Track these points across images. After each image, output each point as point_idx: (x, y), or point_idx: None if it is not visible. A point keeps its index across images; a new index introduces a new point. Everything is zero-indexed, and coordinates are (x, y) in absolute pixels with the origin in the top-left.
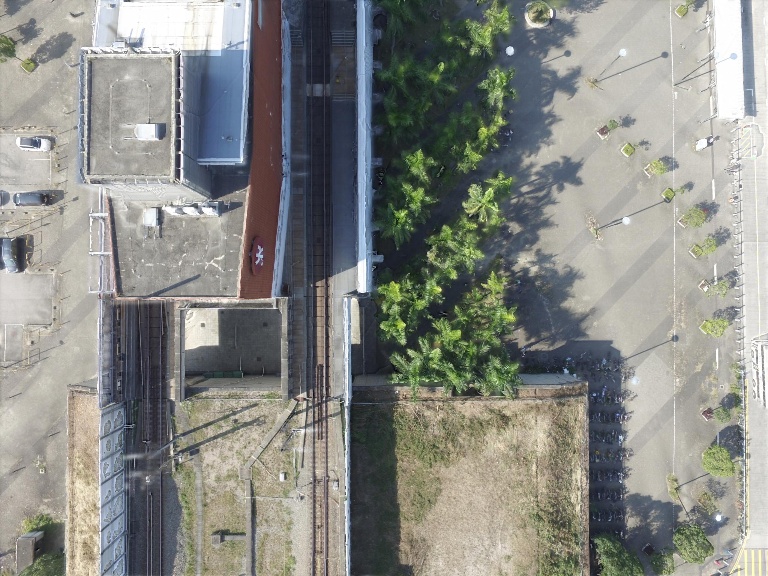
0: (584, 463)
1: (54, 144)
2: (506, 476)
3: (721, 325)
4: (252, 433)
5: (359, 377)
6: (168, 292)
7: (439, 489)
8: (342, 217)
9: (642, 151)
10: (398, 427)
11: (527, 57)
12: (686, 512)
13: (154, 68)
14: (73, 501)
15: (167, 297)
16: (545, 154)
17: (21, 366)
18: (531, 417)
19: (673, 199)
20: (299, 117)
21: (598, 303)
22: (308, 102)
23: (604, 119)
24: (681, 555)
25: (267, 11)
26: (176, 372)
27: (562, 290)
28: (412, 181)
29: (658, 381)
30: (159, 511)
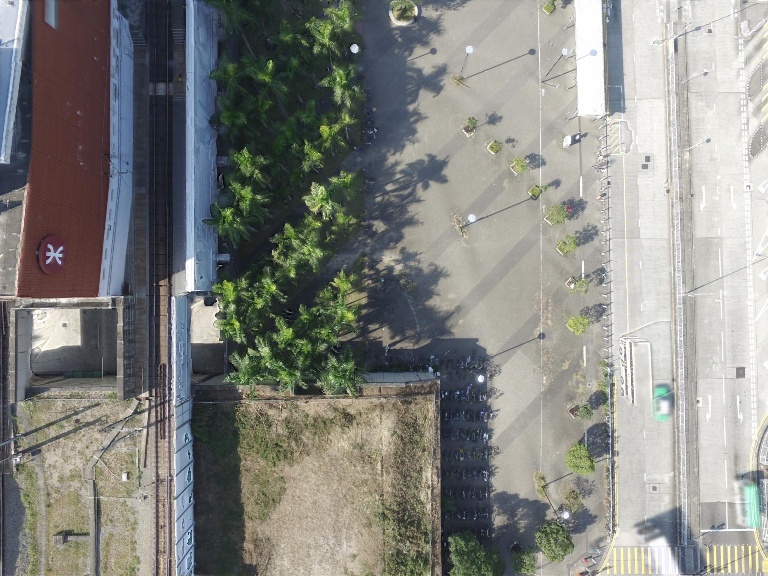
0: (435, 461)
1: None
2: (351, 475)
3: (582, 322)
4: (94, 433)
5: (219, 376)
6: None
7: (283, 488)
8: (182, 216)
9: (508, 148)
10: (241, 426)
11: (392, 55)
12: (554, 510)
13: None
14: None
15: None
16: (410, 152)
17: None
18: (376, 415)
19: (540, 196)
20: (141, 116)
21: (464, 301)
22: (151, 101)
23: (470, 116)
24: (543, 553)
25: (70, 9)
26: (11, 372)
27: (427, 288)
28: (243, 179)
29: (524, 379)
30: (0, 512)
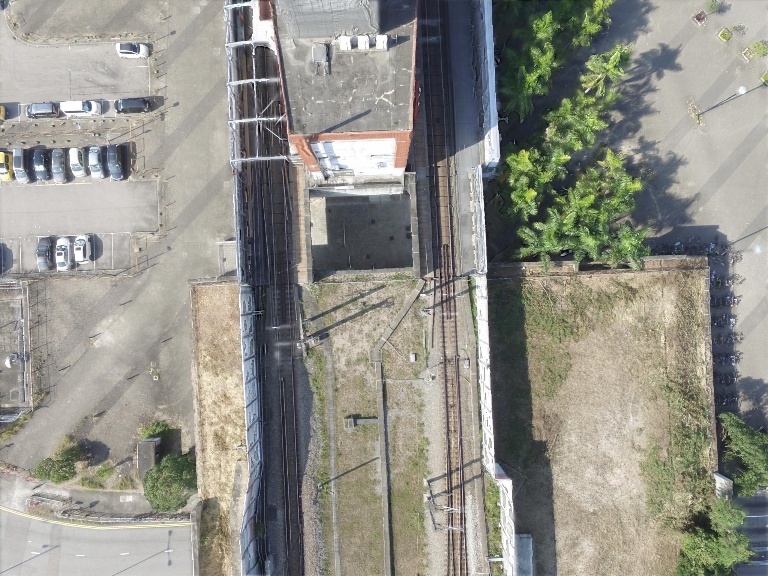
0: None
1: (152, 50)
2: (635, 349)
3: None
4: (381, 315)
5: None
6: (340, 128)
7: (569, 364)
8: (463, 94)
9: (739, 35)
10: (526, 303)
11: None
12: None
13: None
14: (200, 395)
15: (340, 133)
16: (644, 42)
17: (130, 274)
18: (657, 289)
19: None
20: None
21: (703, 188)
22: None
23: (700, 5)
24: None
25: None
26: (307, 252)
27: (667, 176)
28: (539, 47)
29: (765, 264)
30: (292, 396)
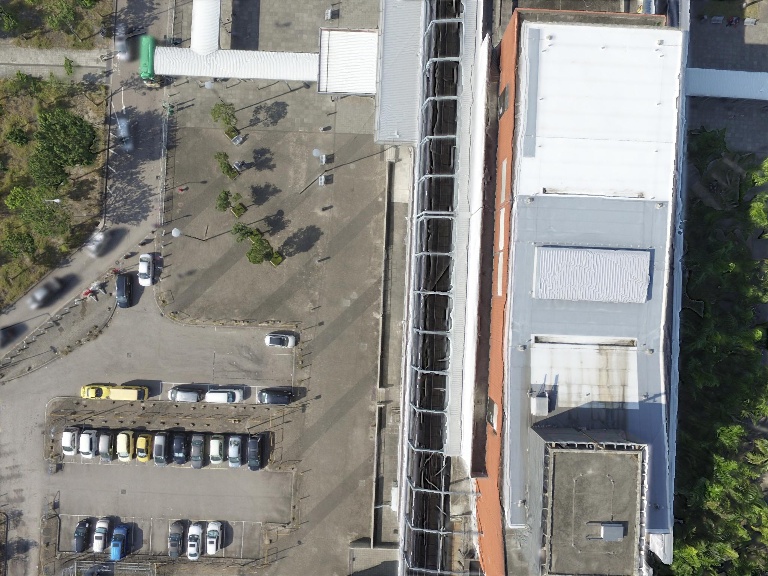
0: None
1: (298, 340)
2: None
3: None
4: None
5: None
6: None
7: None
8: None
9: None
10: None
11: None
12: None
13: (618, 463)
14: None
15: None
16: None
17: (258, 564)
18: None
19: None
20: None
21: None
22: None
23: None
24: None
25: None
26: None
27: None
28: (719, 448)
29: None
30: None
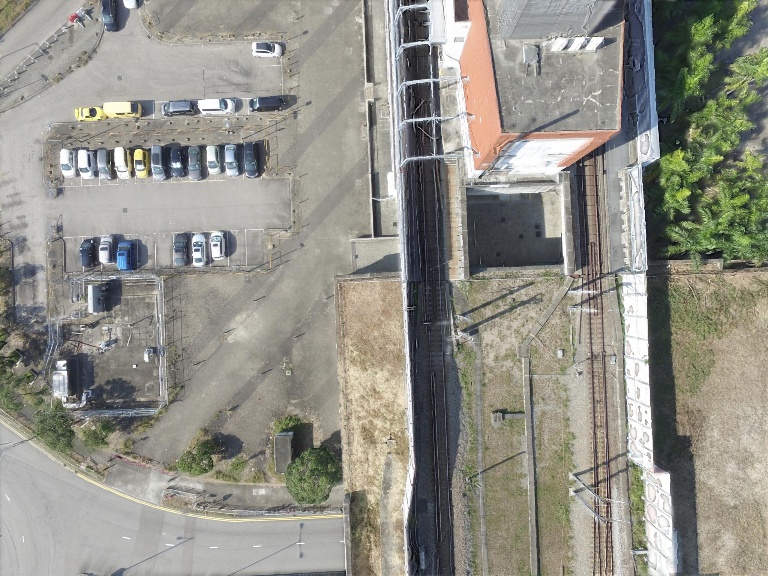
0: None
1: (285, 50)
2: None
3: None
4: (529, 311)
5: None
6: (549, 128)
7: (712, 361)
8: None
9: None
10: (672, 300)
11: None
12: None
13: None
14: (346, 390)
15: (550, 132)
16: (767, 44)
17: (263, 270)
18: None
19: None
20: None
21: None
22: None
23: None
24: None
25: None
26: (464, 249)
27: None
28: None
29: None
30: (443, 391)
